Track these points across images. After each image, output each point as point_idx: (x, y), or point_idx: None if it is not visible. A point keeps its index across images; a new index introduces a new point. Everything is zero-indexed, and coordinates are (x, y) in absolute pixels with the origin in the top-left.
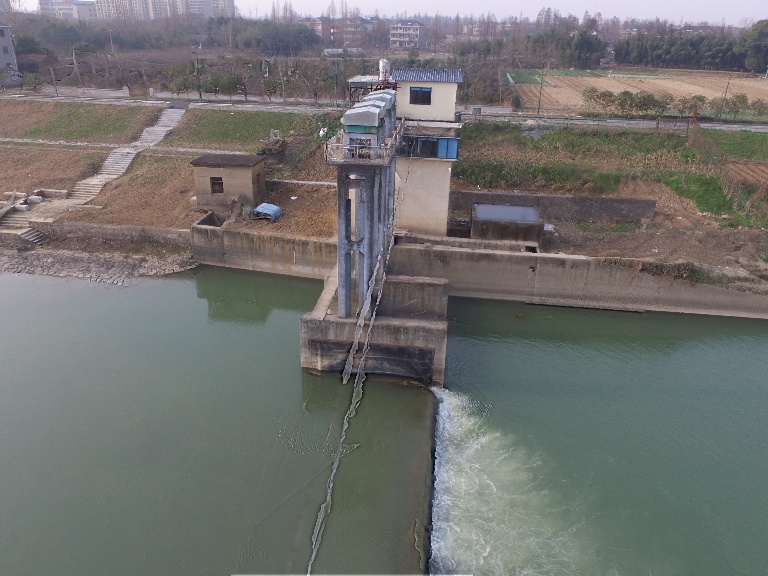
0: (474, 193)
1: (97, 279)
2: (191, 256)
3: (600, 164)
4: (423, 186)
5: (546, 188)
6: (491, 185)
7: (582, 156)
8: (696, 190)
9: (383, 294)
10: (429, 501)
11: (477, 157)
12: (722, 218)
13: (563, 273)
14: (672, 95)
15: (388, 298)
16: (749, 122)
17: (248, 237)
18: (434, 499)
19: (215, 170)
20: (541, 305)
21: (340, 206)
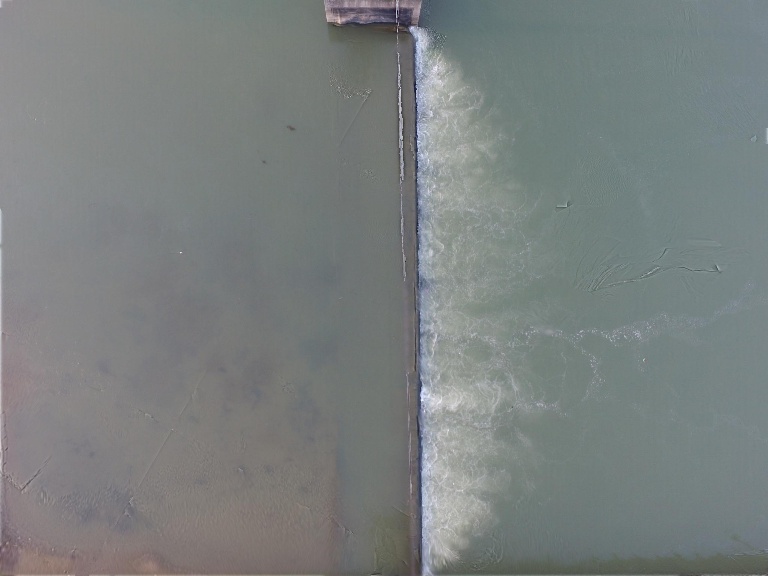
0: None
1: None
2: None
3: None
4: None
5: None
6: None
7: None
8: None
9: None
10: (415, 122)
11: None
12: None
13: None
14: None
15: None
16: None
17: None
18: (417, 119)
19: None
20: None
21: None
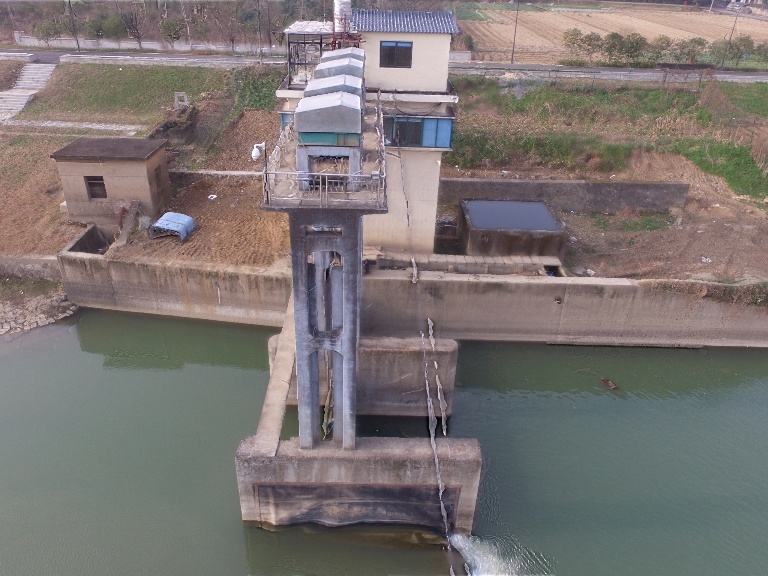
0: (458, 181)
1: None
2: (64, 296)
3: (605, 132)
4: (400, 186)
5: (542, 166)
6: (473, 164)
7: (578, 120)
8: (725, 164)
9: (360, 368)
10: None
11: None
12: (765, 203)
13: (599, 304)
14: (669, 38)
15: (367, 373)
16: (753, 70)
17: (147, 270)
18: None
19: (90, 166)
20: (567, 346)
21: (297, 280)
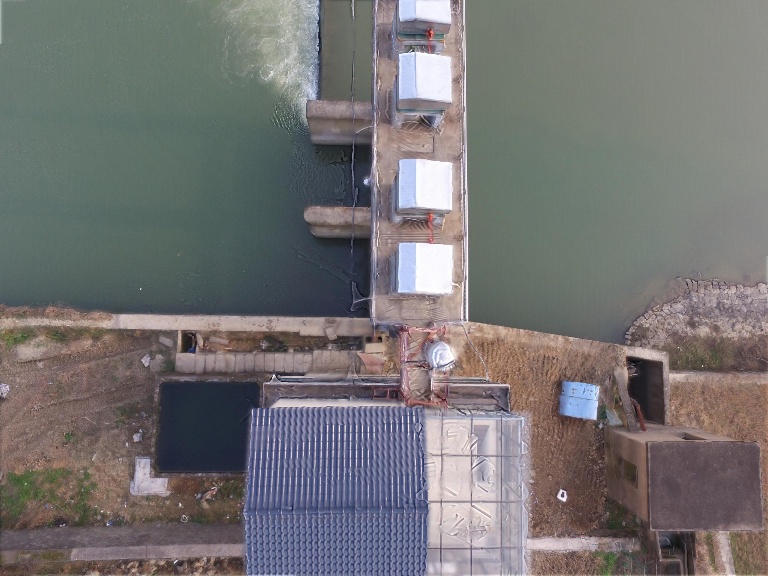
0: None
1: (719, 283)
2: None
3: None
4: None
5: None
6: None
7: None
8: None
9: None
10: None
11: None
12: None
13: None
14: None
15: None
16: None
17: None
18: (319, 5)
19: None
20: None
21: None
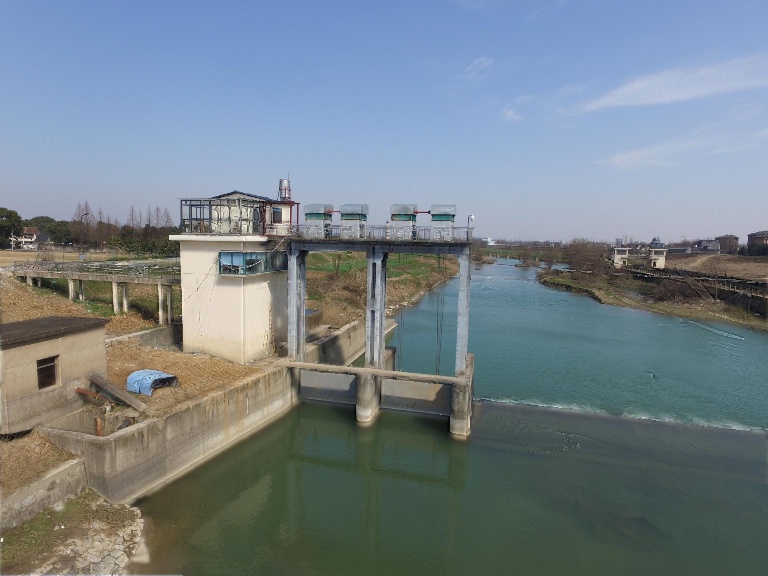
0: None
1: None
2: (105, 503)
3: None
4: (281, 297)
5: None
6: None
7: None
8: None
9: None
10: None
11: (151, 293)
12: None
13: (355, 335)
14: None
15: None
16: None
17: (199, 409)
18: None
19: (46, 345)
20: None
21: None
